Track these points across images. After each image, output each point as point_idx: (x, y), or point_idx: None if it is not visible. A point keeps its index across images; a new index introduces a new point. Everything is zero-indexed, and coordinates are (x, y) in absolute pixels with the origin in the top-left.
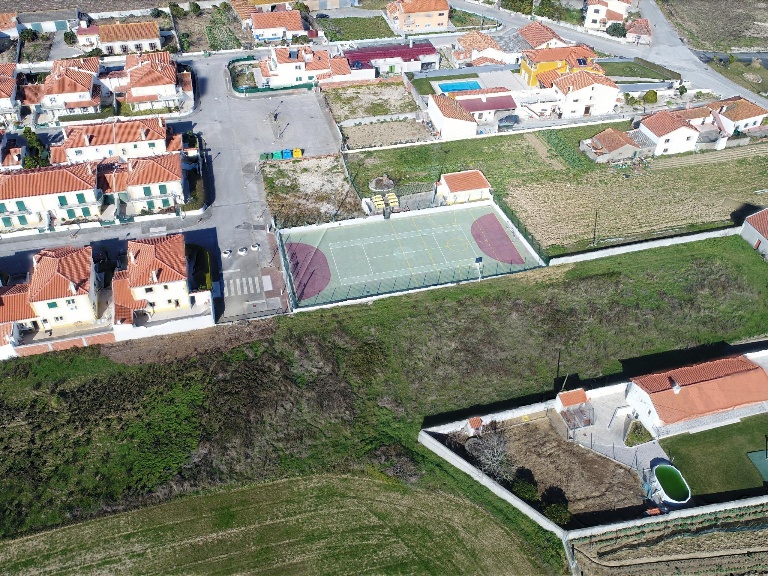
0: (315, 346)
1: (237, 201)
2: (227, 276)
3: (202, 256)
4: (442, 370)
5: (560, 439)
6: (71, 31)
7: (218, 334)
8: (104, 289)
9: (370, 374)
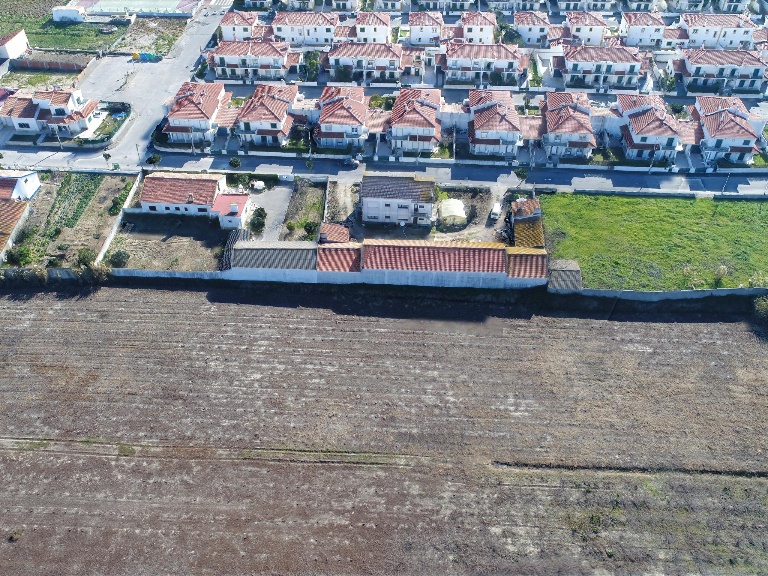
0: None
1: (200, 36)
2: (230, 6)
3: (237, 3)
4: None
5: None
6: (254, 221)
7: None
8: (288, 3)
9: None
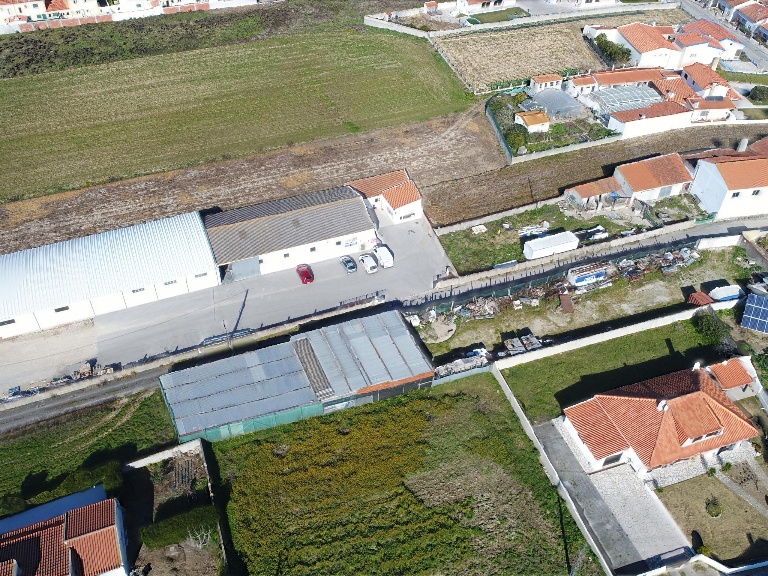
0: (309, 5)
1: None
2: None
3: None
4: (372, 8)
5: (427, 19)
6: None
7: (260, 6)
8: None
9: (338, 11)
